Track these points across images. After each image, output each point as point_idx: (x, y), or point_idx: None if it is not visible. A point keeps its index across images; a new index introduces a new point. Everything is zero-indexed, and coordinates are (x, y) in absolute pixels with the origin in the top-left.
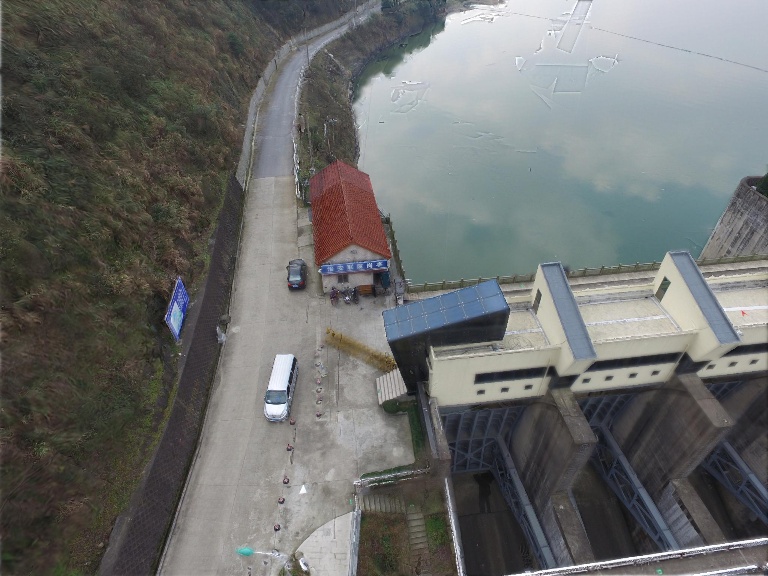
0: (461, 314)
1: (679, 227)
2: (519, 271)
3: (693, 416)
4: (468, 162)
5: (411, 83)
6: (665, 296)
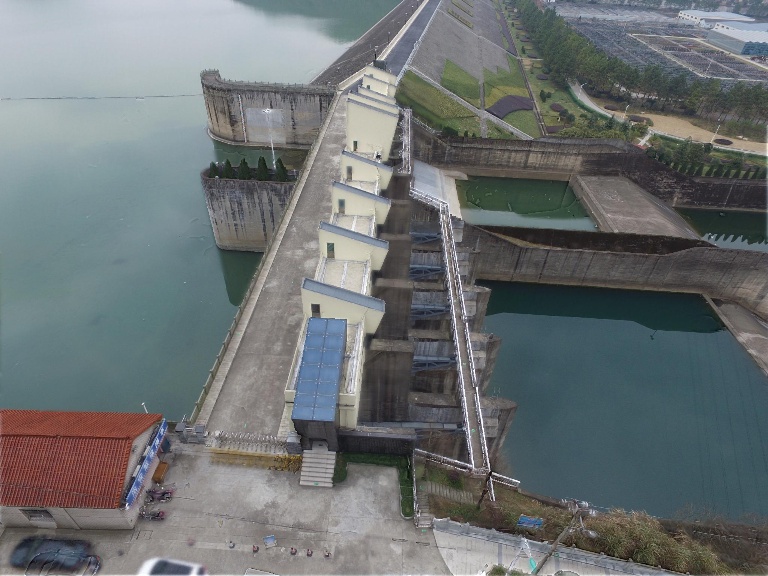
0: (334, 353)
1: (173, 235)
2: (137, 355)
3: (398, 295)
4: None
5: None
6: (336, 253)
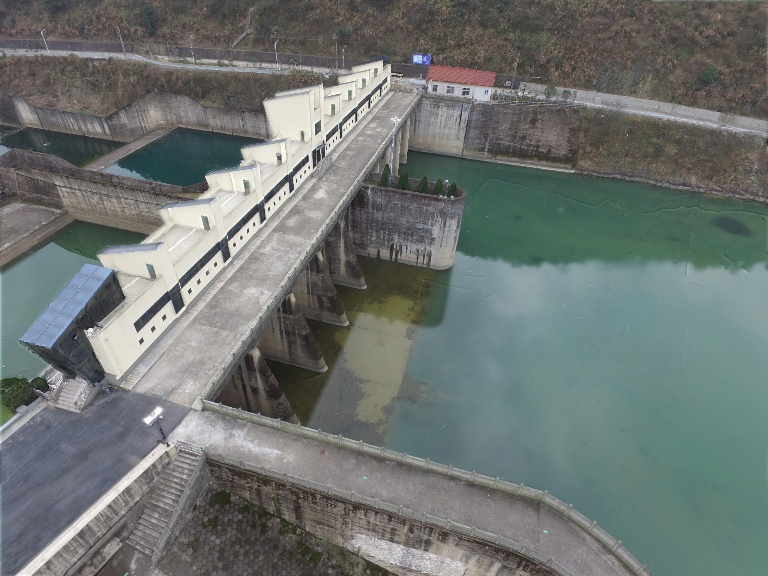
0: None
1: (504, 284)
2: None
3: None
4: (651, 229)
5: None
6: None
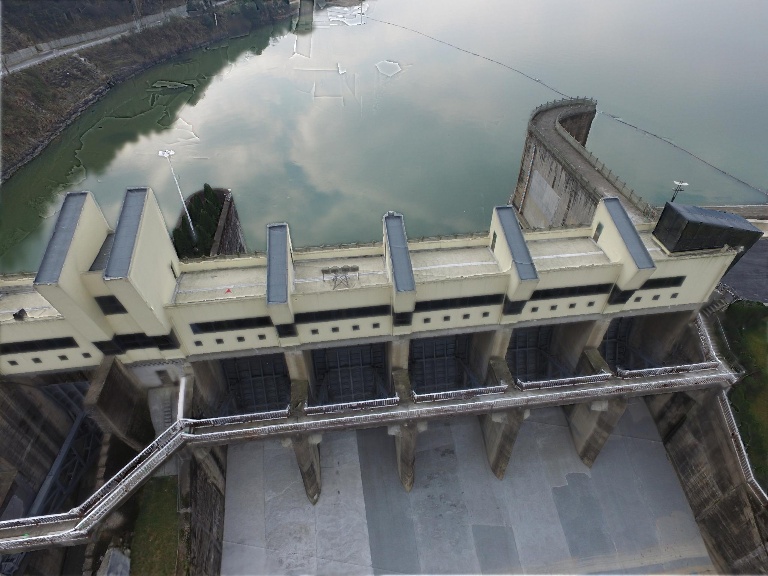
0: None
1: (257, 236)
2: None
3: None
4: (130, 169)
5: (173, 87)
6: None
